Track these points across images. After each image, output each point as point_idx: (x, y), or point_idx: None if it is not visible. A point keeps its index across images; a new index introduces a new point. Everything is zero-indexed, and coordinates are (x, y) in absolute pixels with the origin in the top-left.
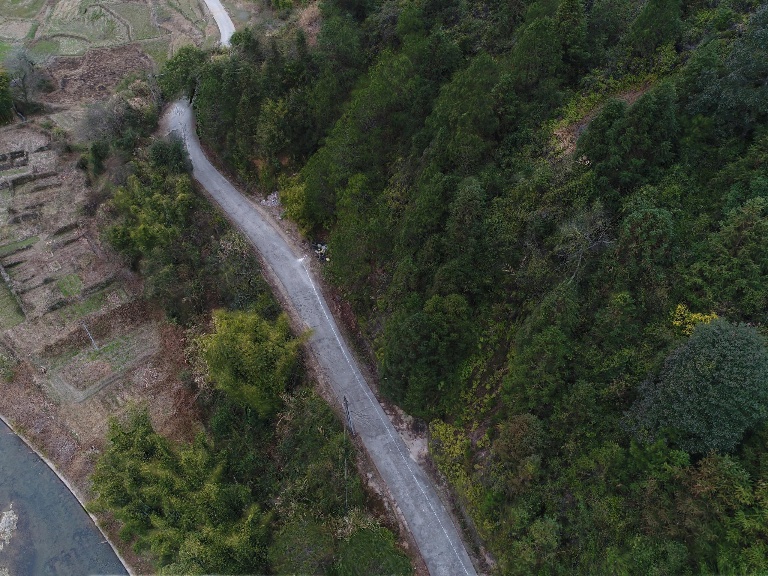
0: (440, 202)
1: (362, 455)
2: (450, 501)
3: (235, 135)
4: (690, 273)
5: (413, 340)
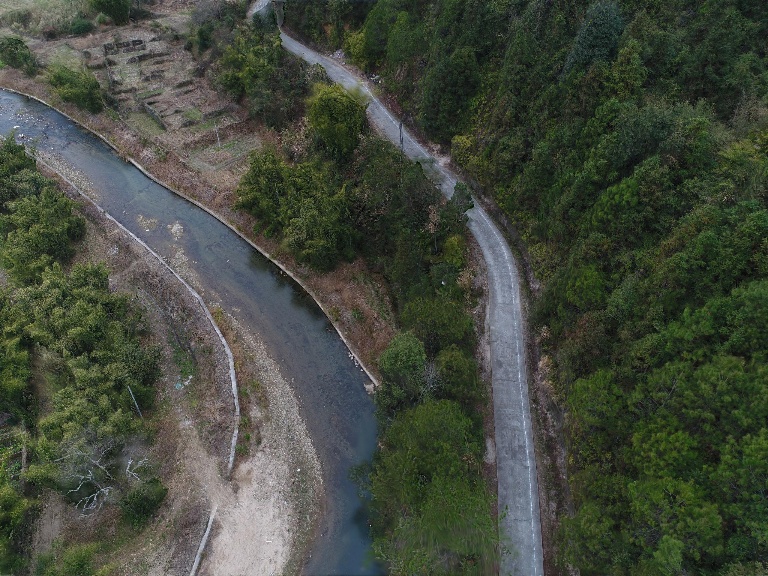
0: (459, 5)
1: (410, 162)
2: (464, 180)
3: (312, 7)
4: (595, 4)
5: (443, 73)
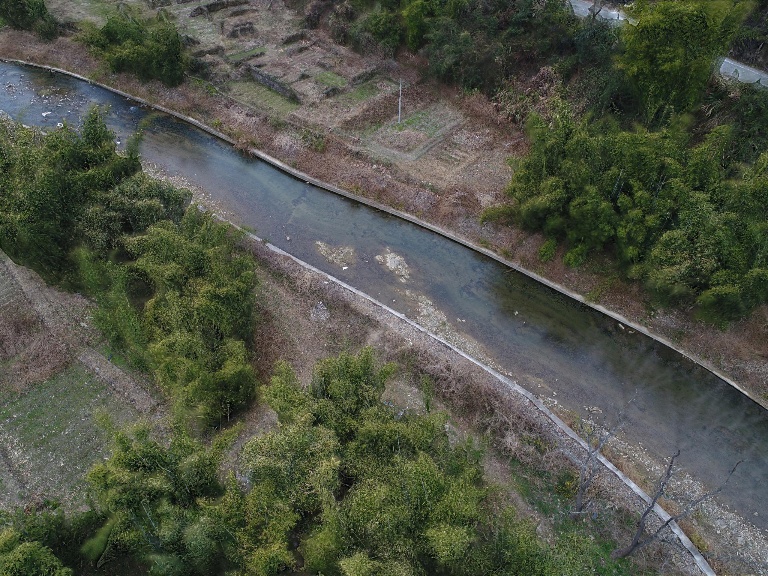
0: None
1: None
2: None
3: None
4: None
5: None
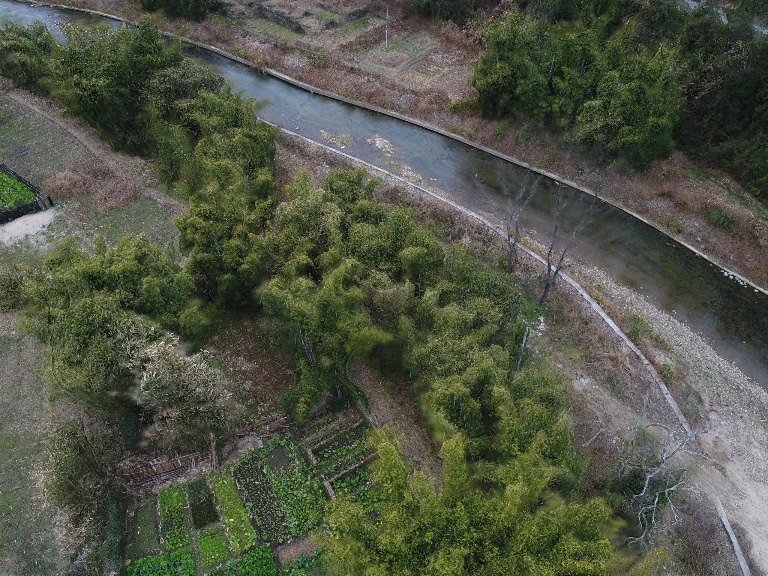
0: None
1: None
2: None
3: None
4: None
5: None
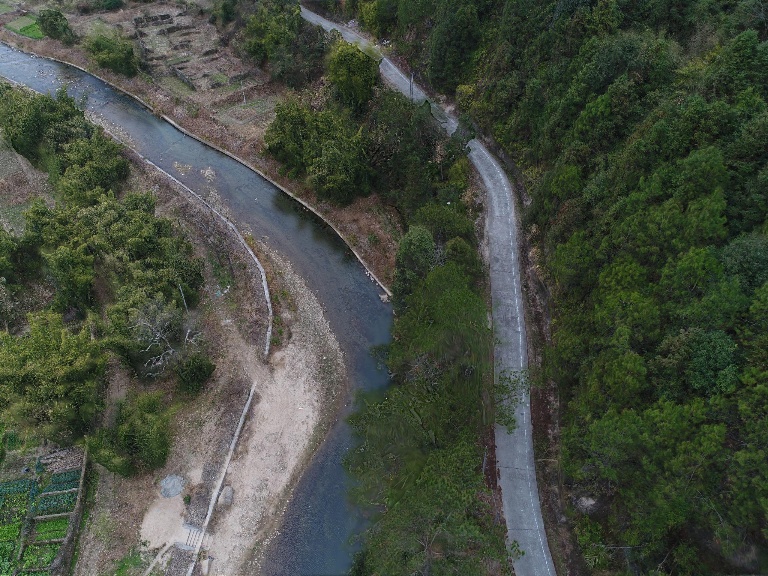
0: None
1: None
2: None
3: None
4: None
5: (449, 28)
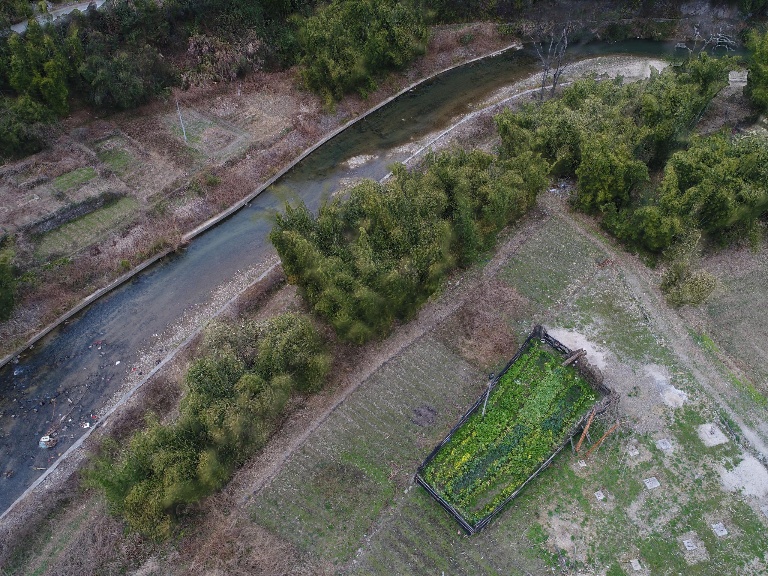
0: None
1: None
2: None
3: None
4: None
5: None
